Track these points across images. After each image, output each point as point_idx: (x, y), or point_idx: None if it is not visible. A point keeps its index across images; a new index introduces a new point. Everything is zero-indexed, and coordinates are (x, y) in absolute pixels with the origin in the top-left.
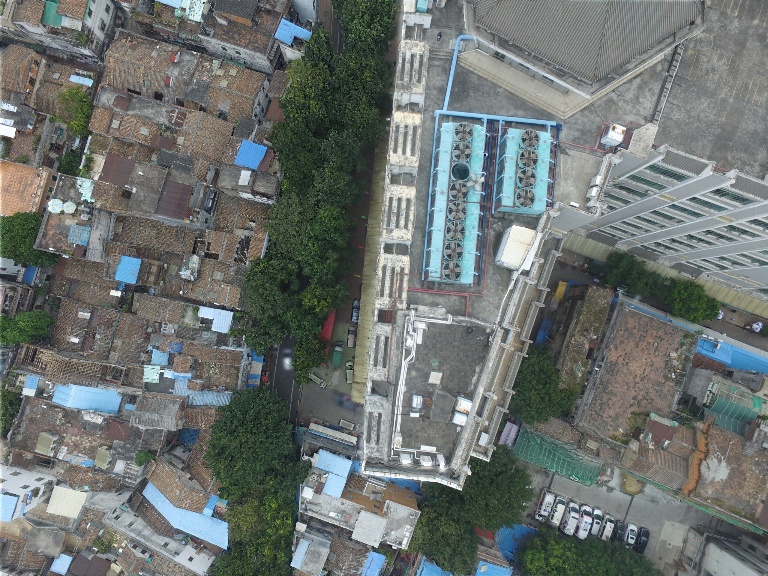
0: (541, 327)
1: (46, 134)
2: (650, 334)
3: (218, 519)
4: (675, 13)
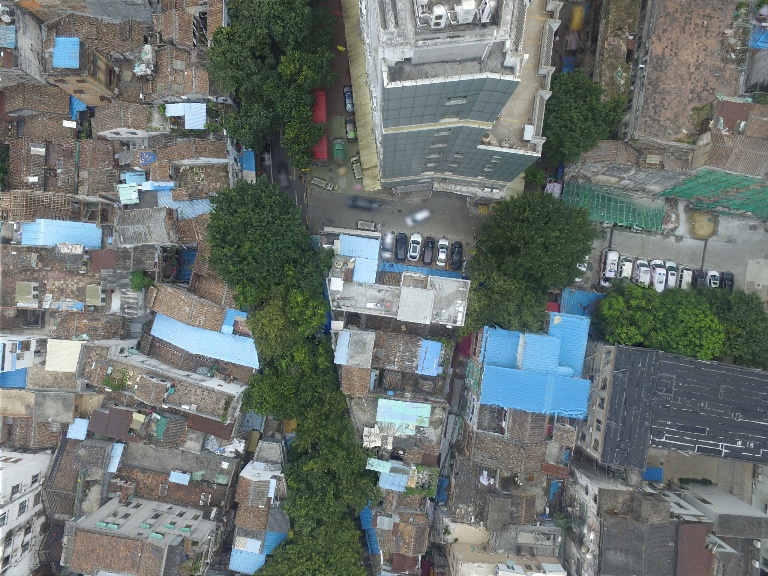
0: (568, 7)
1: None
2: (696, 14)
3: (241, 336)
4: None
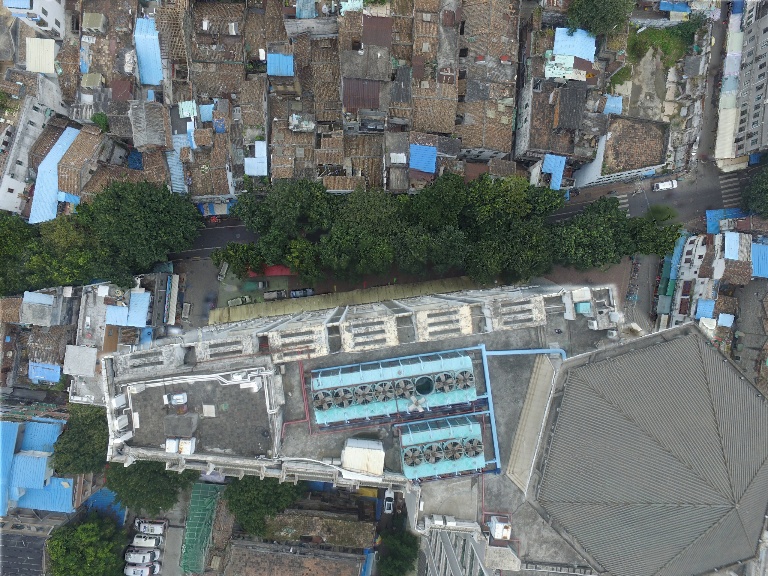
0: None
1: None
2: None
3: (57, 208)
4: (626, 568)
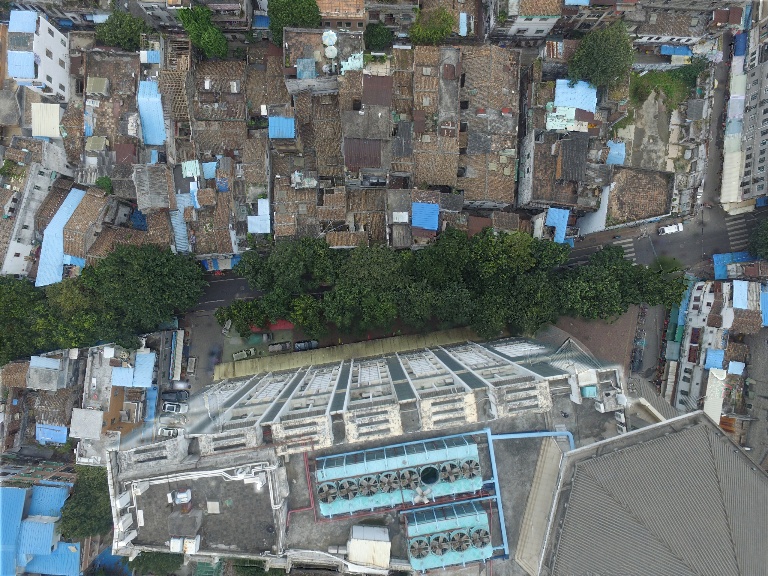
0: None
1: (400, 8)
2: None
3: (63, 271)
4: None
